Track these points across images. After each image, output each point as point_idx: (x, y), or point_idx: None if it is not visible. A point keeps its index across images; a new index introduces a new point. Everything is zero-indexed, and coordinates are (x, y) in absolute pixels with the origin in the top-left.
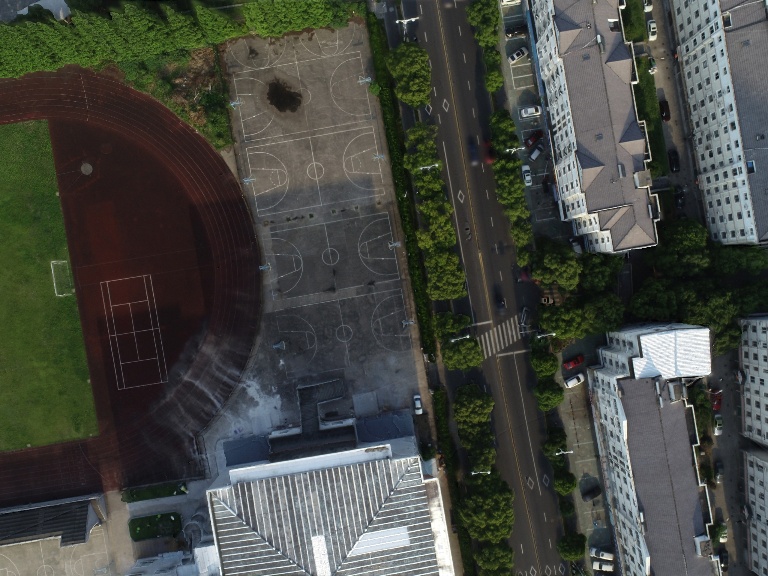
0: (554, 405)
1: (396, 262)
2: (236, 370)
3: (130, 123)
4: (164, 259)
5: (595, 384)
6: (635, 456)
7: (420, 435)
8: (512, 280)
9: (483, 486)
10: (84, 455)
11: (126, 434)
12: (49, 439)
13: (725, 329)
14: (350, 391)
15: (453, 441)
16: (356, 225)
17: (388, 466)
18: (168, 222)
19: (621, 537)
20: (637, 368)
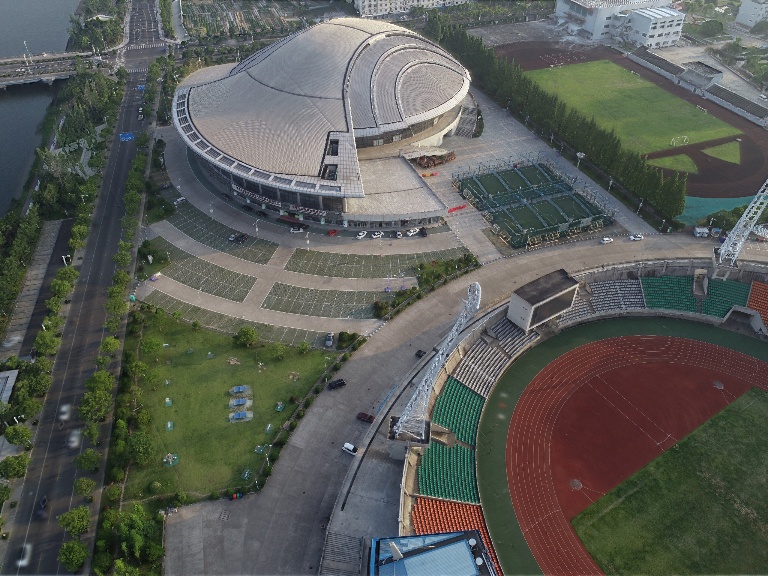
0: None
1: None
2: None
3: None
4: None
5: None
6: None
7: None
8: None
9: None
10: None
11: None
12: None
13: None
14: None
15: None
16: None
17: None
18: None
19: None
20: None
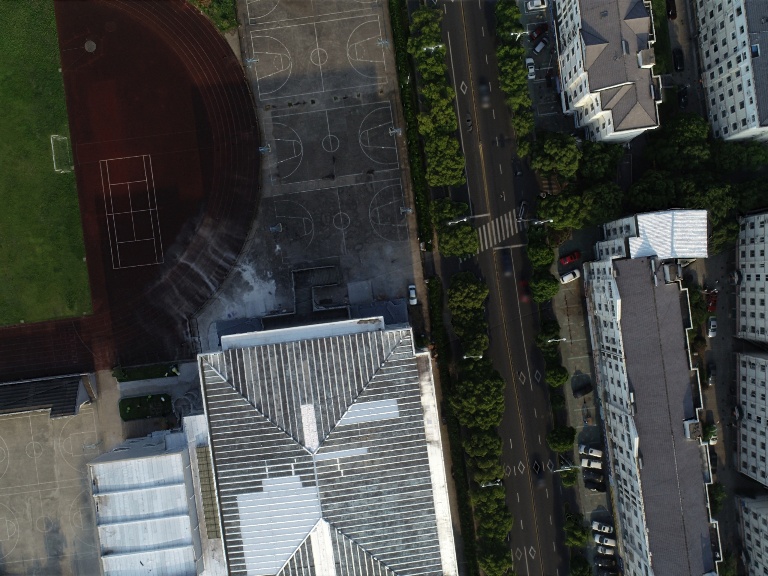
0: (549, 296)
1: (396, 151)
2: (232, 254)
3: (135, 2)
4: (164, 139)
5: (591, 277)
6: (628, 337)
7: (413, 325)
8: (512, 173)
9: (474, 372)
10: (77, 333)
11: (120, 314)
12: (43, 316)
13: (723, 223)
14: (345, 279)
15: (446, 333)
16: (357, 113)
17: (380, 338)
18: (170, 103)
19: (611, 430)
20: (633, 248)
